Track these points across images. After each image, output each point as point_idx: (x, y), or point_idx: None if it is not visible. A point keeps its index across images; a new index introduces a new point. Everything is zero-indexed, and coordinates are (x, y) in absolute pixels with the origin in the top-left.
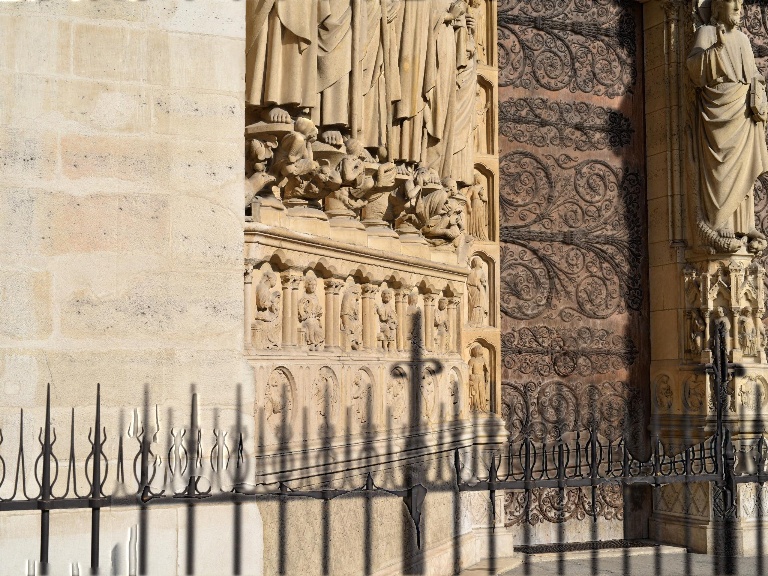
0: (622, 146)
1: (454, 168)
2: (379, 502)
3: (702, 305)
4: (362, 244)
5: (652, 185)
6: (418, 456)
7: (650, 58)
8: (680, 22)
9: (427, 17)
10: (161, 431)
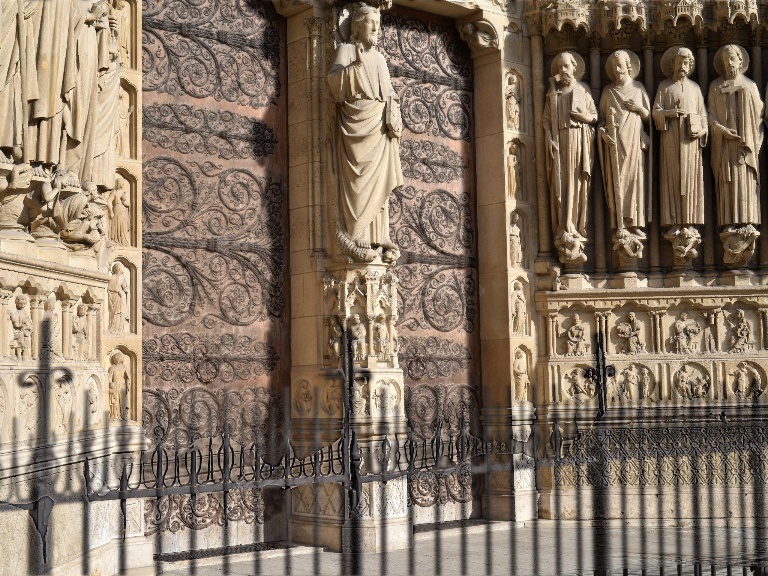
0: (266, 156)
1: (95, 172)
2: (10, 517)
3: (340, 312)
4: None
5: (294, 195)
6: (53, 467)
7: (293, 71)
8: (322, 38)
9: (67, 16)
10: None
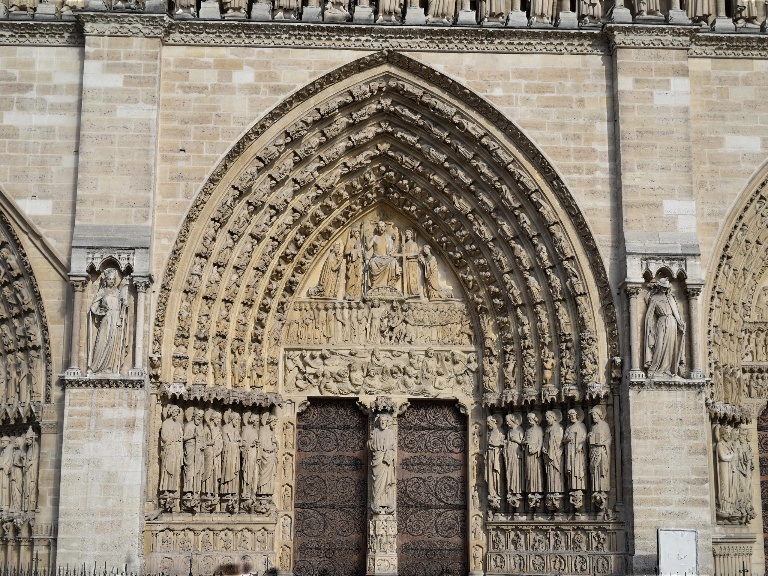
0: (358, 470)
1: (264, 490)
2: None
3: None
4: (210, 520)
5: None
6: None
7: None
8: None
9: (236, 450)
10: (119, 572)
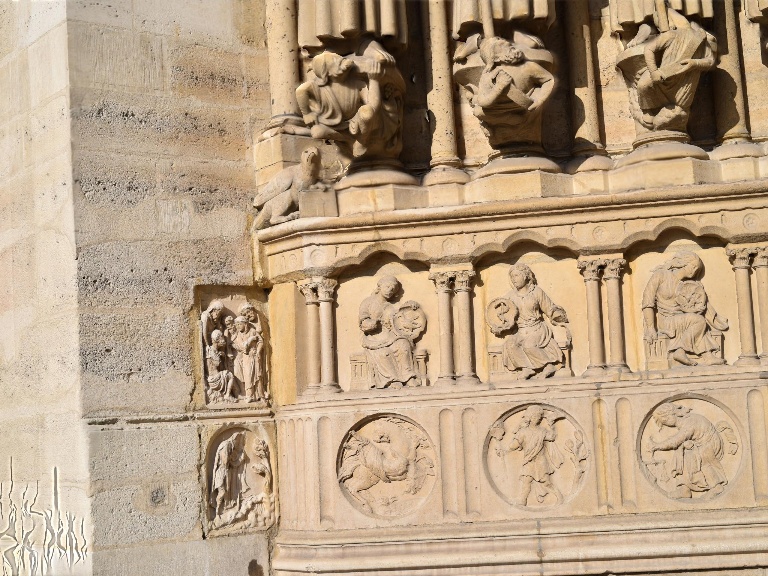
0: None
1: None
2: None
3: None
4: (672, 183)
5: None
6: None
7: None
8: None
9: None
10: None
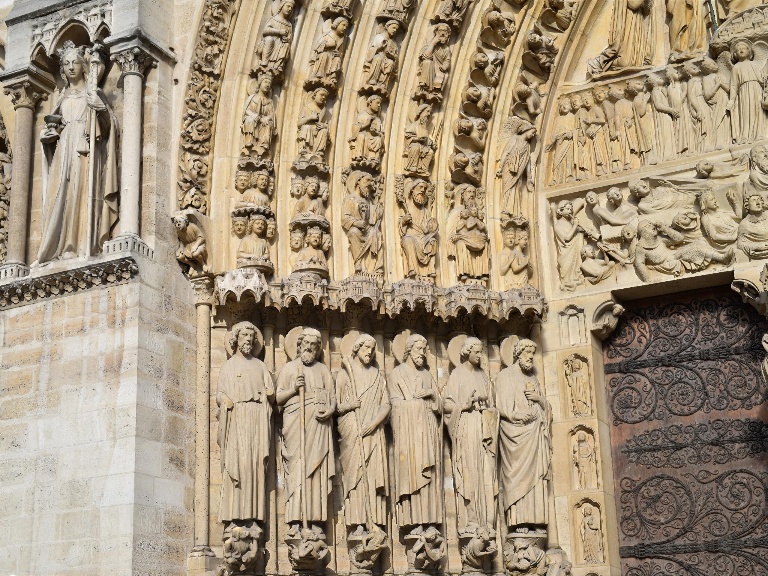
0: (765, 451)
1: (518, 513)
2: None
3: None
4: None
5: None
6: None
7: None
8: None
9: (420, 418)
10: None
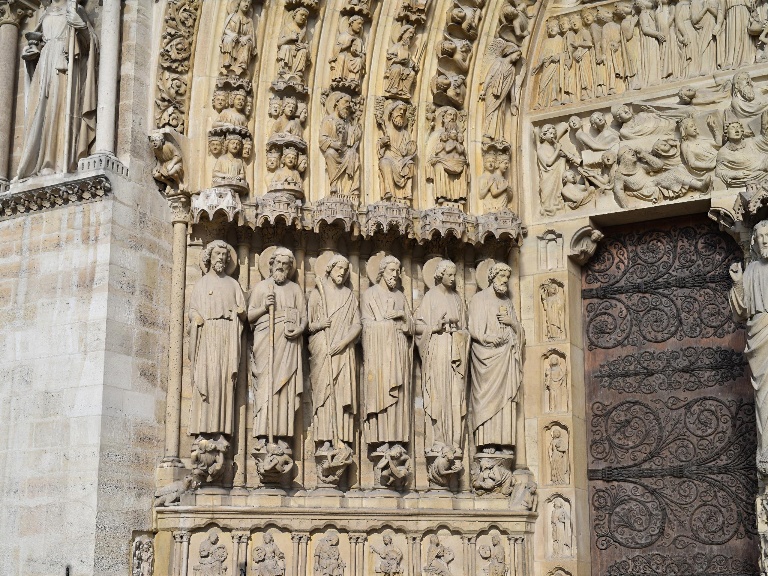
0: (735, 380)
1: (485, 434)
2: None
3: (757, 529)
4: (331, 506)
5: None
6: None
7: None
8: None
9: (390, 339)
10: None
